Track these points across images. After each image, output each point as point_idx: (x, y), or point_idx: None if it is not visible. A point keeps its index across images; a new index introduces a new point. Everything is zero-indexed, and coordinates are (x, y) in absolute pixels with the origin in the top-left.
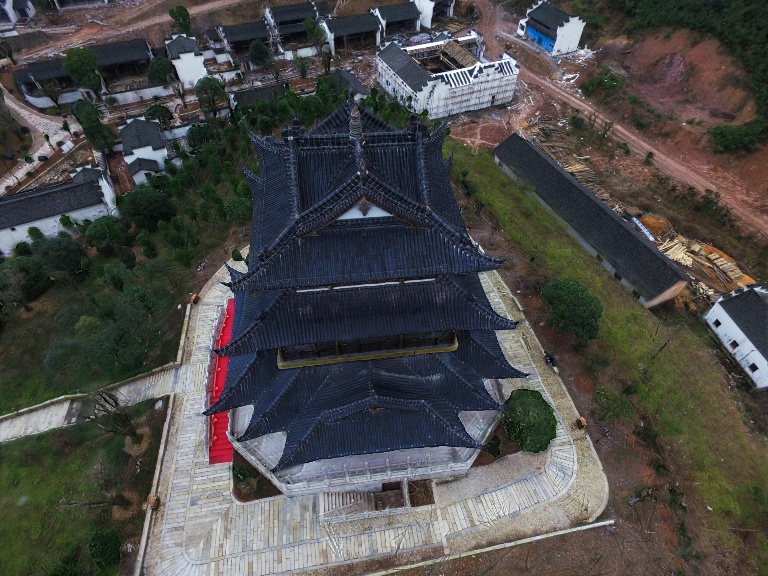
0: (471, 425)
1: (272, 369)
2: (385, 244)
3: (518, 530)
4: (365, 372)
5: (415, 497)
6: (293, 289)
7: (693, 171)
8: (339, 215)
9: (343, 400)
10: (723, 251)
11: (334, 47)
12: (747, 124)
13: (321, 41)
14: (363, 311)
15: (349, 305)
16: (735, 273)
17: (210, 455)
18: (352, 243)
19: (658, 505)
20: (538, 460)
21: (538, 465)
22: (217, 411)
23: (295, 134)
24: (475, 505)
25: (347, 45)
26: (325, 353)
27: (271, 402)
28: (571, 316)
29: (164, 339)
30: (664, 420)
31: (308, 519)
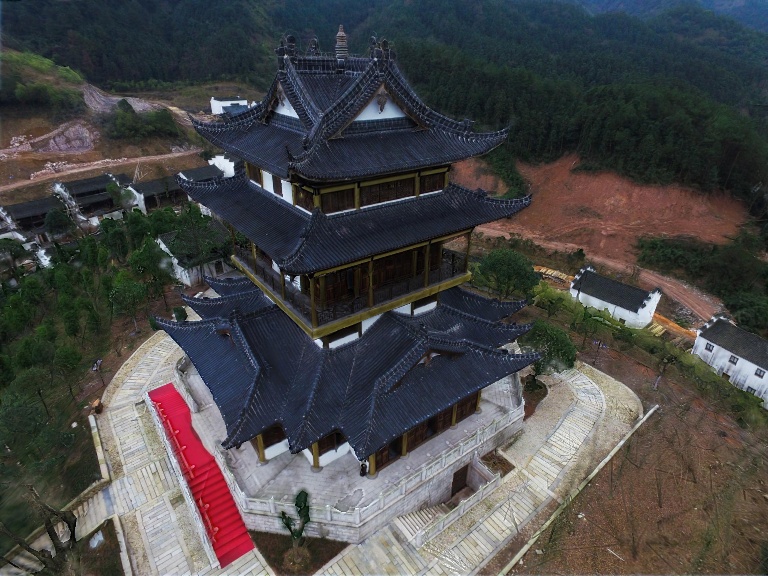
0: (497, 383)
1: (282, 379)
2: (403, 143)
3: (600, 451)
4: (397, 330)
5: (494, 471)
6: (322, 212)
7: (492, 229)
8: (362, 108)
9: (389, 365)
10: (545, 267)
11: (145, 207)
12: (506, 194)
13: (130, 203)
14: (398, 223)
15: (382, 221)
16: (563, 276)
17: (218, 555)
18: (375, 144)
19: (670, 385)
20: (566, 394)
21: (570, 397)
22: (237, 442)
23: (290, 53)
24: (550, 450)
25: (159, 204)
26: (358, 306)
27: (303, 407)
28: (516, 271)
29: (65, 468)
30: (623, 328)
31: (399, 553)
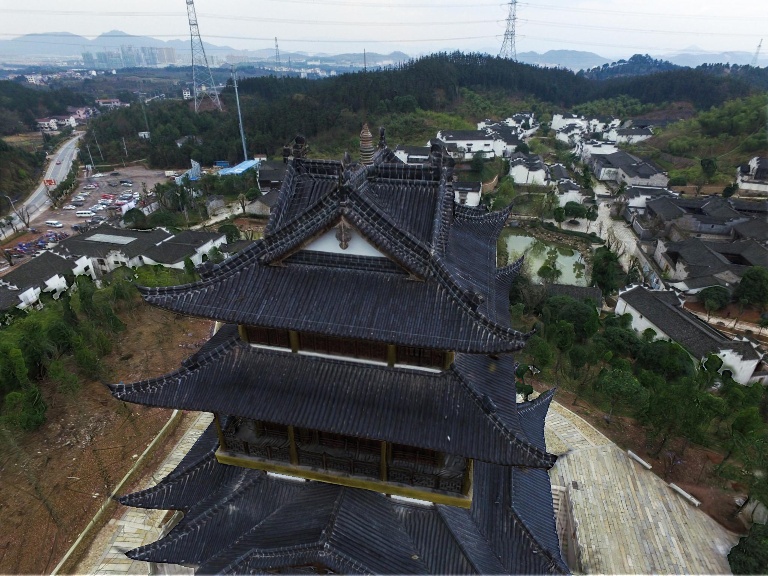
0: None
1: None
2: None
3: None
4: None
5: None
6: None
7: None
8: None
9: None
10: None
11: None
12: None
13: None
14: None
15: None
16: None
17: None
18: None
19: None
20: None
21: None
22: None
23: None
24: (118, 572)
25: None
26: None
27: None
28: None
29: None
30: None
31: None
